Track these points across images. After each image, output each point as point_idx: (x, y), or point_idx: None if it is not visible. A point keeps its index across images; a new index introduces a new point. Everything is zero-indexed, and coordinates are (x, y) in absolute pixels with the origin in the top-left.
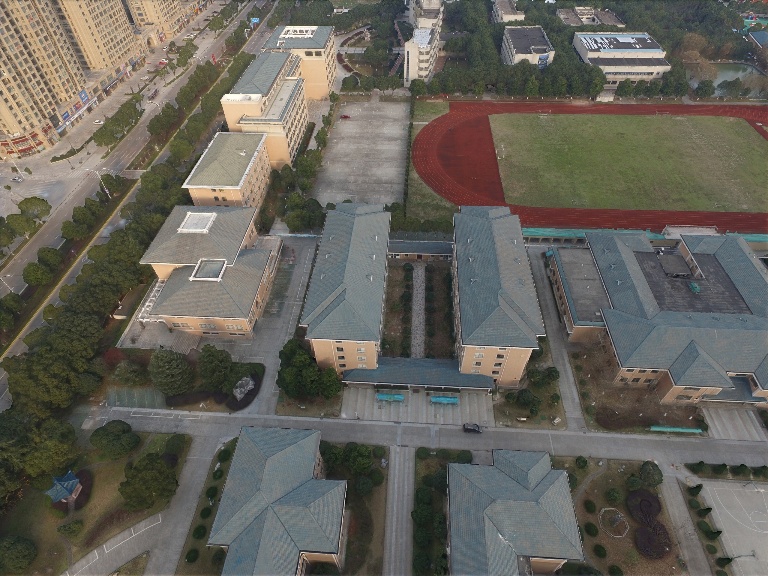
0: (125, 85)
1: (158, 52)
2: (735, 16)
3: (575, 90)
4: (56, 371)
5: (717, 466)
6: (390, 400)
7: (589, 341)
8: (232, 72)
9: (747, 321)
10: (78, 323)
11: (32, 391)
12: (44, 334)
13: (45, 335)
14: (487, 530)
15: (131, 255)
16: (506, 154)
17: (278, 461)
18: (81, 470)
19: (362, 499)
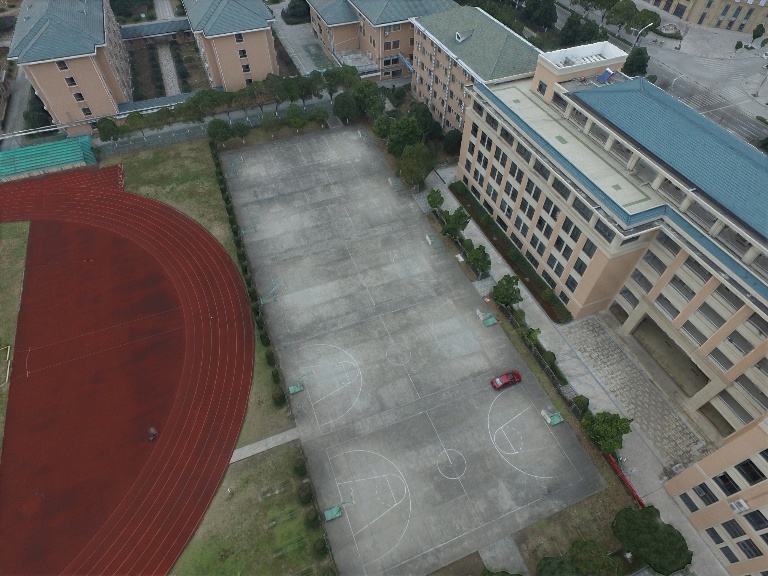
0: None
1: None
2: None
3: None
4: None
5: None
6: None
7: None
8: None
9: None
10: None
11: None
12: None
13: None
14: None
15: None
16: None
17: None
18: None
19: None
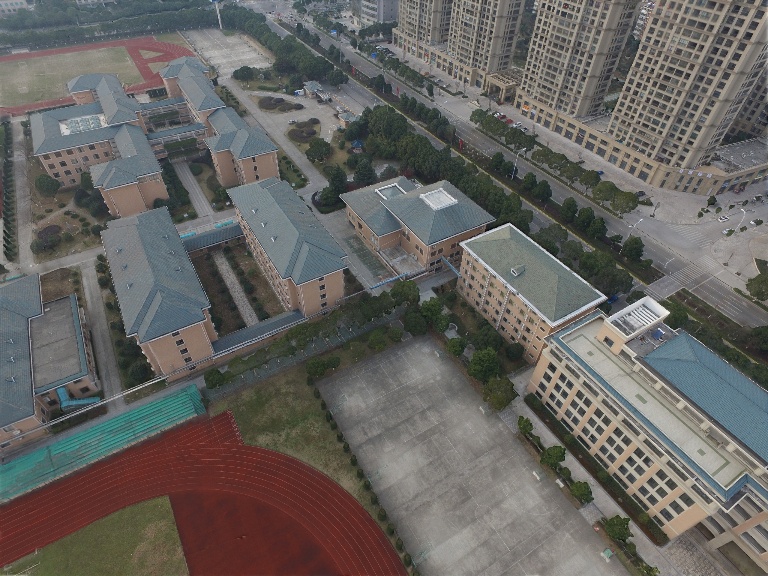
0: None
1: None
2: None
3: None
4: None
5: None
6: None
7: None
8: None
9: None
10: None
11: None
12: None
13: None
14: None
15: None
16: None
17: None
18: None
19: None
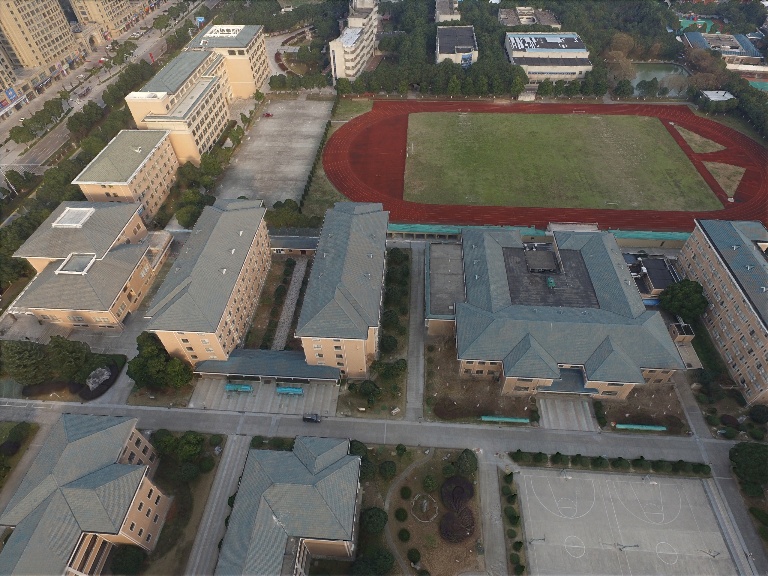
0: (60, 83)
1: (101, 50)
2: (672, 17)
3: (496, 89)
4: None
5: (537, 454)
6: (239, 390)
7: (444, 334)
8: None
9: (588, 315)
10: None
11: None
12: None
13: None
14: (260, 512)
15: (11, 249)
16: (416, 152)
17: (80, 446)
18: None
19: (187, 485)
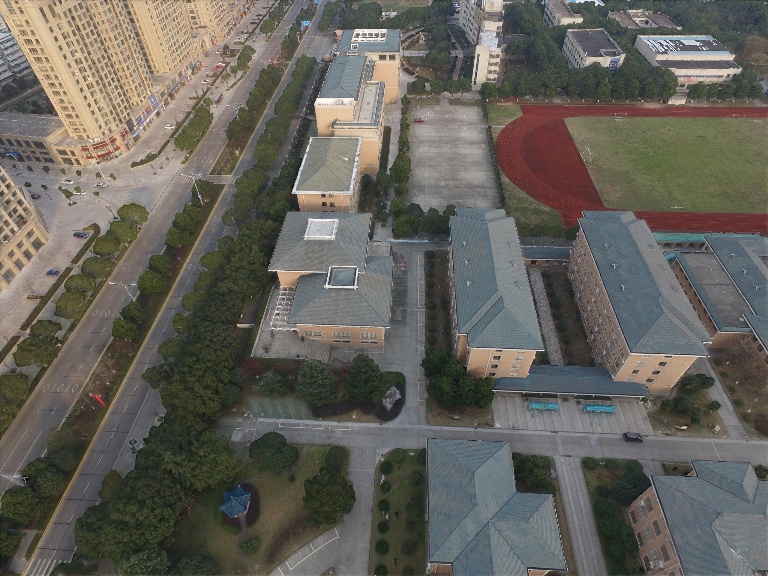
0: (187, 89)
1: (212, 55)
2: None
3: (648, 93)
4: (209, 382)
5: None
6: (542, 409)
7: (731, 347)
8: (296, 75)
9: None
10: (218, 333)
11: (190, 403)
12: (180, 344)
13: (181, 345)
14: (721, 545)
15: (252, 262)
16: (592, 157)
17: (484, 475)
18: (244, 484)
19: None
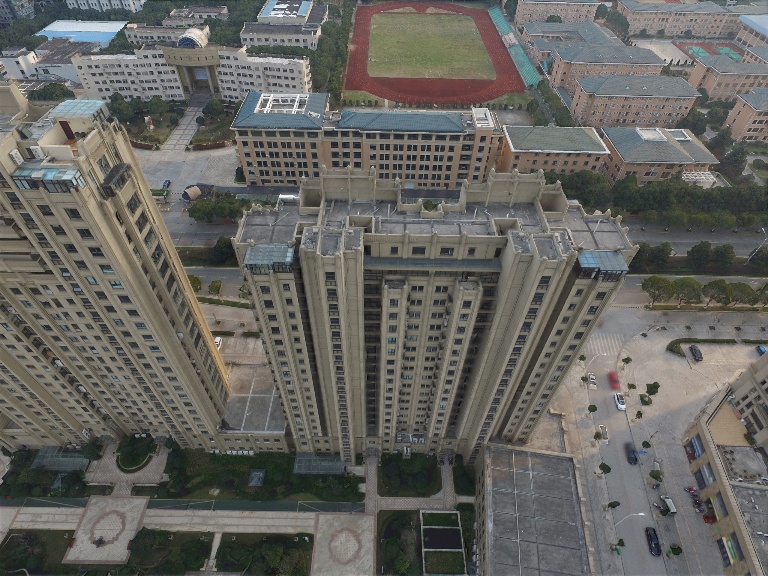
0: None
1: None
2: None
3: (348, 39)
4: None
5: None
6: None
7: None
8: None
9: None
10: None
11: None
12: None
13: None
14: None
15: None
16: (434, 75)
17: None
18: None
19: None
